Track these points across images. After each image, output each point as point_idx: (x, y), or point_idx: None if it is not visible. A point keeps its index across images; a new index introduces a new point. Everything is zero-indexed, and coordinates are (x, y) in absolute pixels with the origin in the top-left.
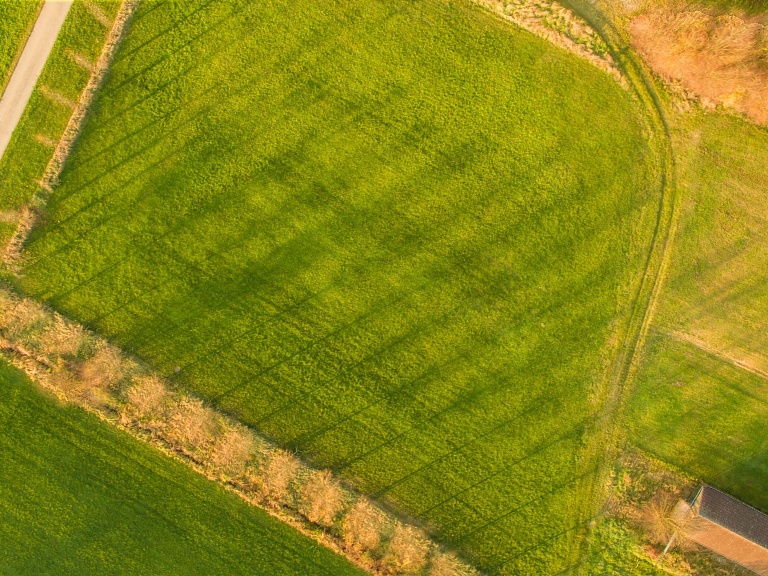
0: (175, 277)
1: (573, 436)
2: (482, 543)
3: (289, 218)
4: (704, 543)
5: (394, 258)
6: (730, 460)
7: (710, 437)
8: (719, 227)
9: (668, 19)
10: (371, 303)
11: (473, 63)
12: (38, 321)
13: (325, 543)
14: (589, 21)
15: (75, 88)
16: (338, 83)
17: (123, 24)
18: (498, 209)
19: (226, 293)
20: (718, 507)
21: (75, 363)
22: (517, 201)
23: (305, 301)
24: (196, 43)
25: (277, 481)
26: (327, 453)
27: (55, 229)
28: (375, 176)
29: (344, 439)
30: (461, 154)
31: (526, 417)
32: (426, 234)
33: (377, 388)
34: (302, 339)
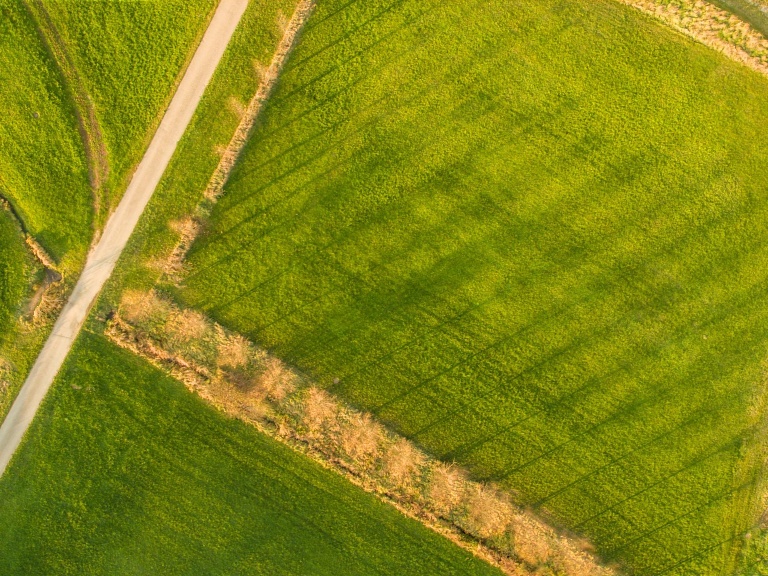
0: (337, 288)
1: (731, 448)
2: (636, 555)
3: (454, 229)
4: None
5: (558, 270)
6: None
7: None
8: None
9: None
10: (533, 315)
11: (646, 75)
12: (198, 332)
13: (480, 555)
14: (765, 34)
15: (243, 98)
16: (509, 95)
17: (294, 34)
18: (665, 221)
19: (388, 304)
20: None
21: (233, 374)
22: (684, 213)
23: (467, 313)
24: (367, 54)
25: (433, 493)
26: (484, 465)
27: (218, 240)
28: (542, 188)
29: (502, 451)
30: (630, 166)
31: (684, 429)
32: (591, 246)
33: (536, 400)
34: (462, 351)
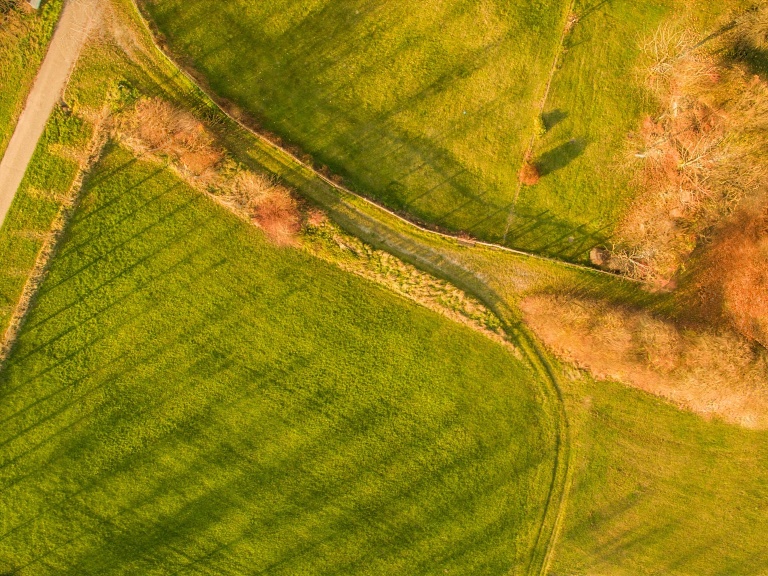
0: (88, 531)
1: None
2: None
3: (198, 476)
4: None
5: (301, 512)
6: None
7: None
8: (612, 482)
9: (557, 299)
10: (280, 553)
11: (372, 335)
12: None
13: None
14: (482, 299)
15: None
16: (242, 353)
17: (29, 299)
18: (400, 467)
19: (139, 545)
20: None
21: None
22: (418, 460)
23: (216, 552)
24: (102, 316)
25: None
26: None
27: None
28: (281, 437)
29: None
30: (363, 418)
31: None
32: (332, 490)
33: None
34: None
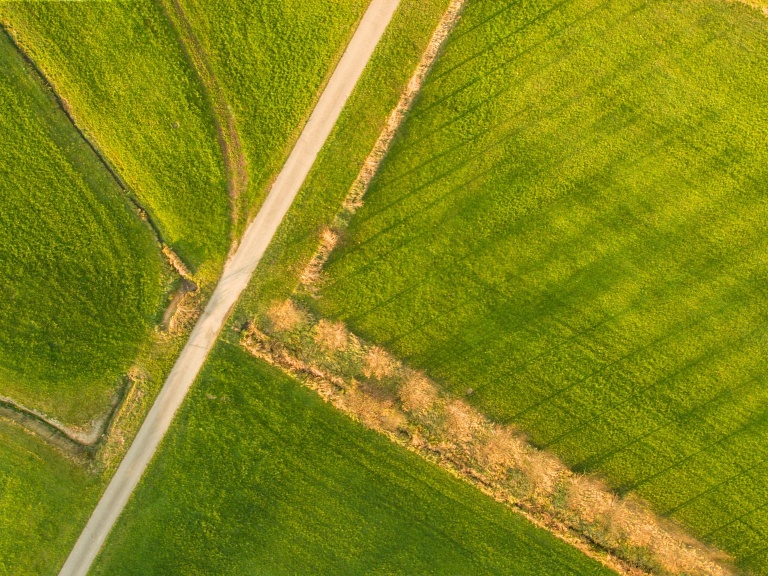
0: (473, 299)
1: None
2: (764, 565)
3: (592, 241)
4: None
5: (694, 281)
6: None
7: None
8: None
9: None
10: (668, 326)
11: None
12: (333, 342)
13: (609, 565)
14: None
15: (384, 109)
16: (651, 107)
17: (438, 46)
18: None
19: (523, 315)
20: None
21: (367, 384)
22: None
23: (602, 324)
24: (509, 66)
25: (564, 503)
26: (615, 475)
27: (355, 250)
28: (681, 200)
29: (633, 461)
30: None
31: None
32: (728, 258)
33: (668, 411)
34: (596, 361)
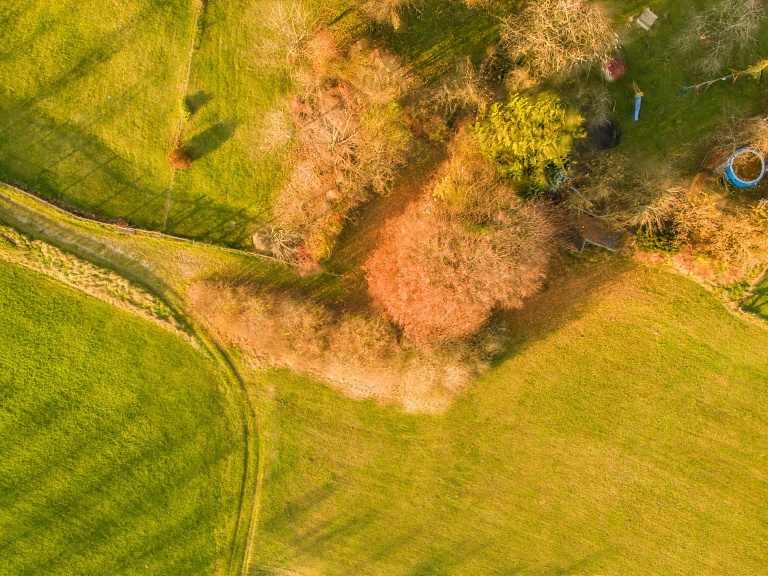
0: None
1: None
2: None
3: None
4: None
5: None
6: None
7: None
8: (305, 472)
9: (224, 286)
10: None
11: (45, 327)
12: None
13: None
14: (150, 287)
15: None
16: None
17: None
18: (88, 461)
19: None
20: None
21: None
22: (106, 454)
23: None
24: None
25: None
26: None
27: None
28: None
29: None
30: (45, 412)
31: None
32: (21, 486)
33: None
34: None
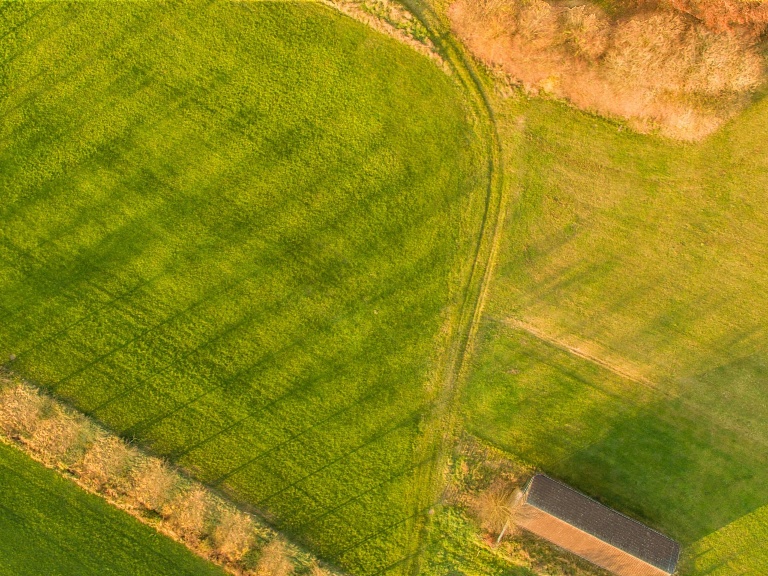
0: (8, 264)
1: (410, 424)
2: (322, 531)
3: (119, 205)
4: (536, 531)
5: (225, 245)
6: (568, 448)
7: (547, 425)
8: (548, 213)
9: None
10: (204, 290)
11: (295, 49)
12: None
13: (164, 531)
14: (408, 6)
15: None
16: (162, 69)
17: None
18: (326, 196)
19: (59, 280)
20: (548, 495)
21: None
22: (345, 187)
23: (138, 288)
24: (21, 30)
25: (115, 469)
26: (164, 441)
27: None
28: (203, 163)
29: (181, 427)
30: (287, 140)
31: (362, 405)
32: (256, 221)
33: (212, 376)
34: (136, 326)
